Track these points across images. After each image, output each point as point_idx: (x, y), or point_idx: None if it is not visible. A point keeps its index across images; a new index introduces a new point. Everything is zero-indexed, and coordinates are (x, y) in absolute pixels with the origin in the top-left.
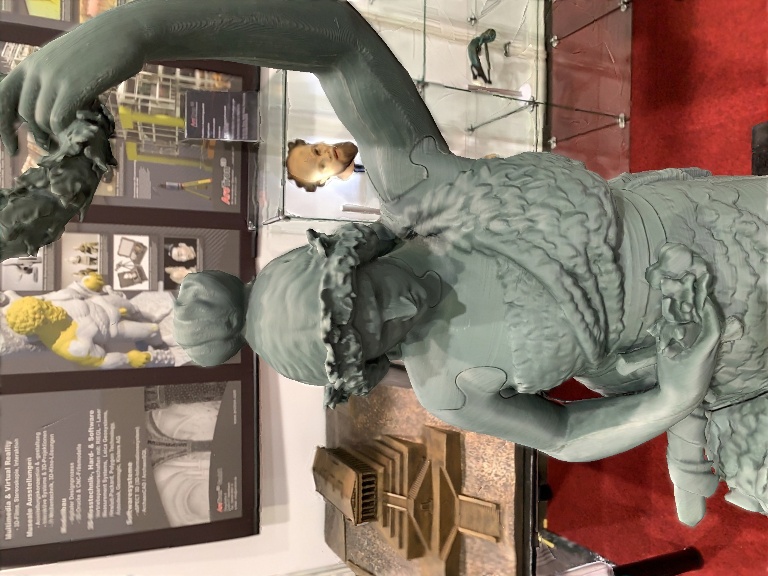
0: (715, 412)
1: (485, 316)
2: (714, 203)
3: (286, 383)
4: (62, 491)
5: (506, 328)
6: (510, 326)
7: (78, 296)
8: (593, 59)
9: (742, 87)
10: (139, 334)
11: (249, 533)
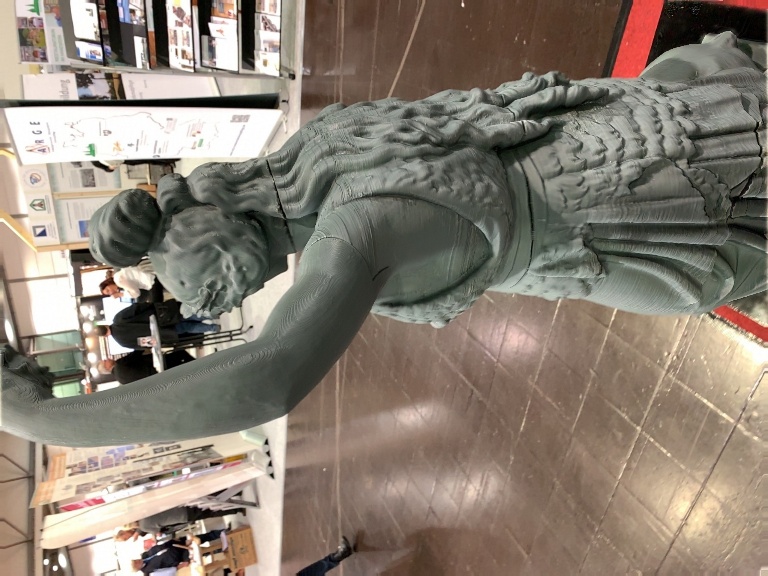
0: None
1: None
2: None
3: None
4: None
5: None
6: None
7: None
8: None
9: None
10: None
11: None
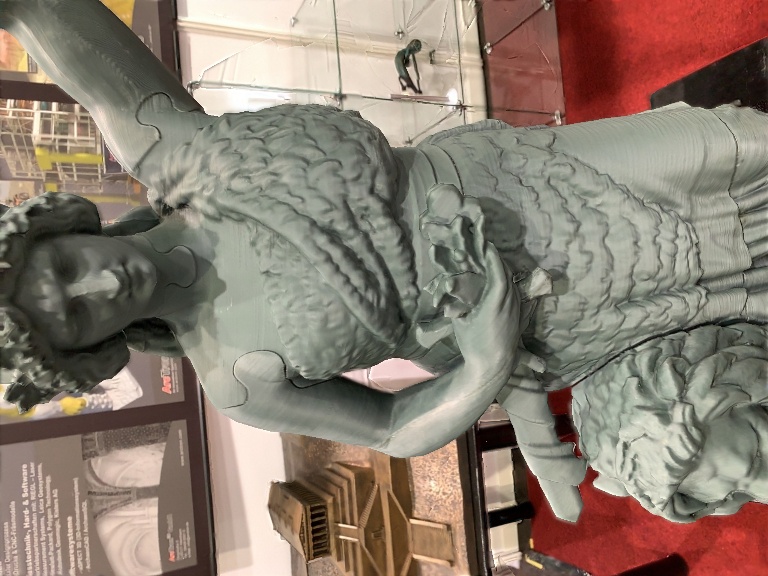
0: (574, 387)
1: (245, 291)
2: (523, 147)
3: None
4: None
5: (268, 302)
6: (269, 299)
7: None
8: (531, 63)
9: (665, 69)
10: None
11: None
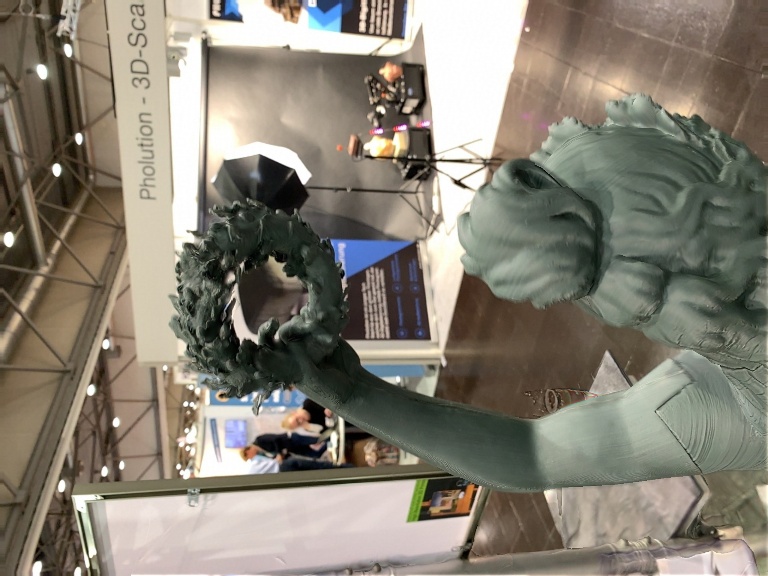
0: None
1: None
2: None
3: None
4: None
5: None
6: None
7: None
8: None
9: None
10: None
11: None
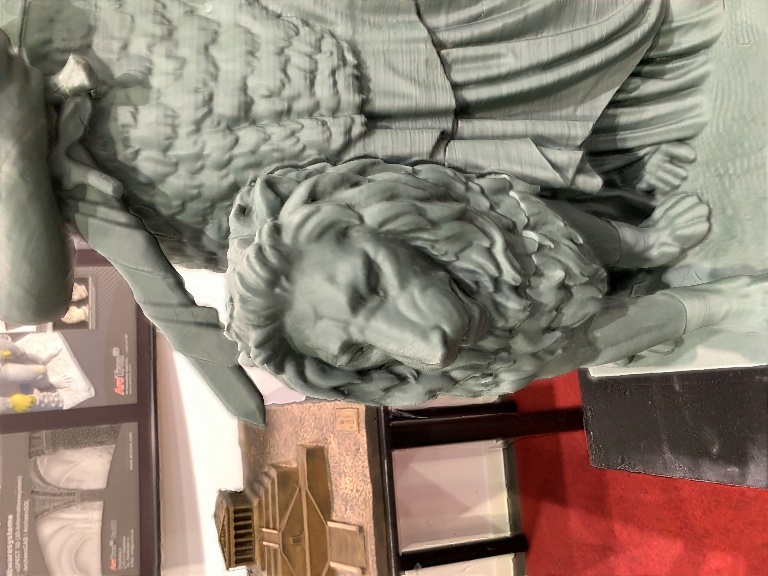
0: None
1: None
2: None
3: (195, 425)
4: None
5: None
6: None
7: None
8: None
9: None
10: (24, 377)
11: None
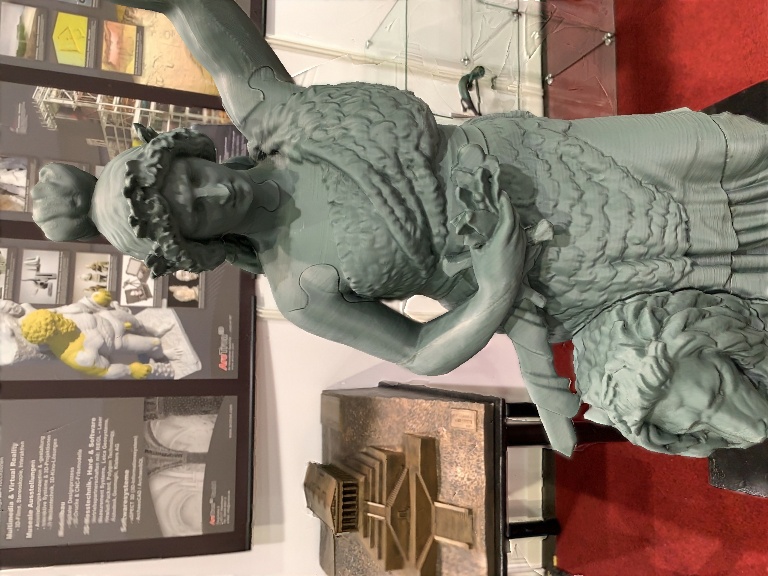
0: (574, 336)
1: (315, 217)
2: (542, 130)
3: (283, 401)
4: (62, 495)
5: (331, 226)
6: (332, 222)
7: (87, 310)
8: (591, 96)
9: None
10: (142, 347)
11: (241, 549)
